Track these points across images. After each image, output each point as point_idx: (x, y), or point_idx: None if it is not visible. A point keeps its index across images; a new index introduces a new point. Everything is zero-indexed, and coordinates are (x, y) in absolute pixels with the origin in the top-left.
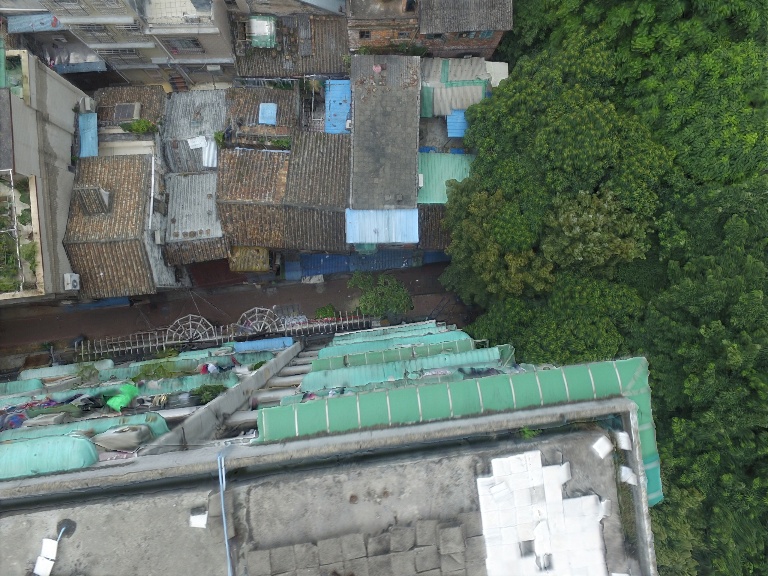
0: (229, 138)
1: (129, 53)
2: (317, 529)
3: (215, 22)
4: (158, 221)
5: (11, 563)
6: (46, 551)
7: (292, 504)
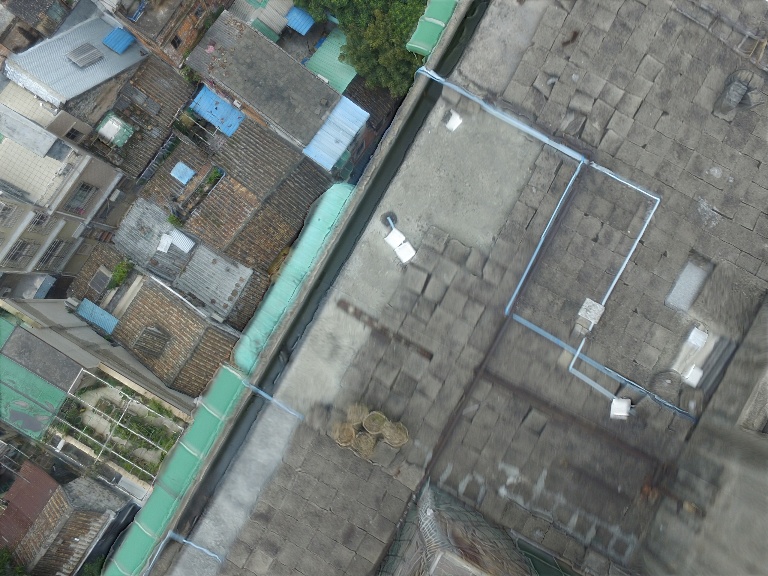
0: (180, 216)
1: (56, 246)
2: (522, 43)
3: (81, 152)
4: (205, 312)
5: (385, 274)
6: (394, 241)
7: (491, 49)
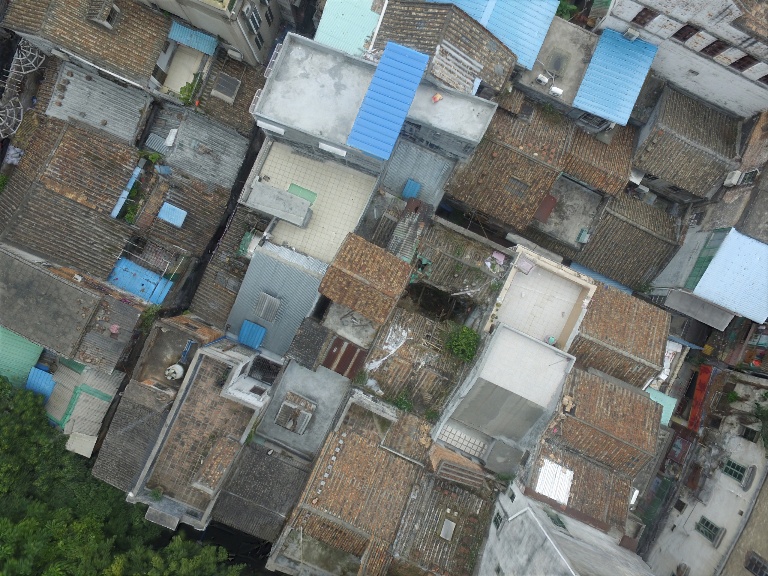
0: None
1: None
2: None
3: None
4: None
5: None
6: None
7: None
